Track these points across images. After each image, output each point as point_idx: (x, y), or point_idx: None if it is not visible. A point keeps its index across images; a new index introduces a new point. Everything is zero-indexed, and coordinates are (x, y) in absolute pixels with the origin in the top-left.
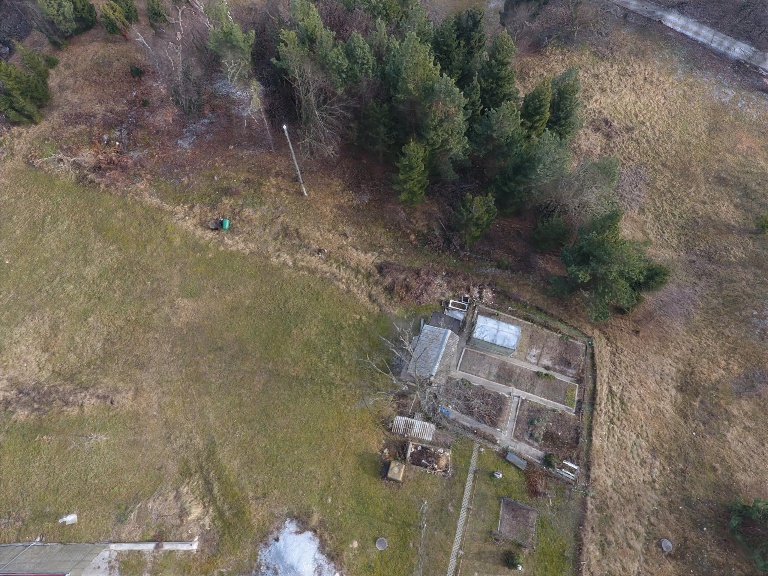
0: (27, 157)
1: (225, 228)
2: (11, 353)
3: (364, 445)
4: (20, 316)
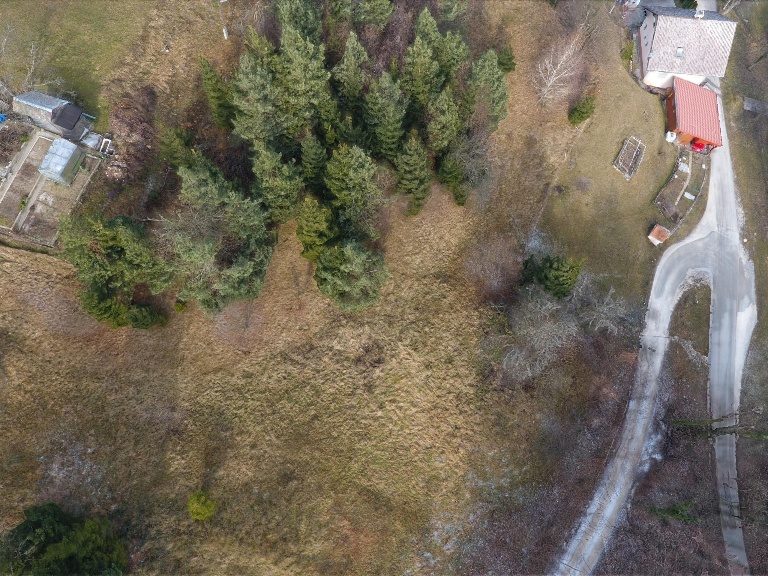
0: None
1: None
2: None
3: None
4: None
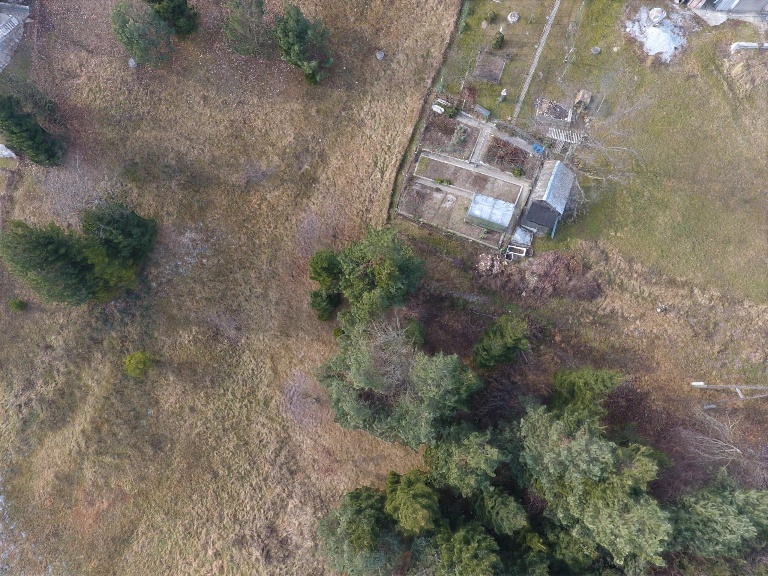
0: None
1: None
2: None
3: None
4: None
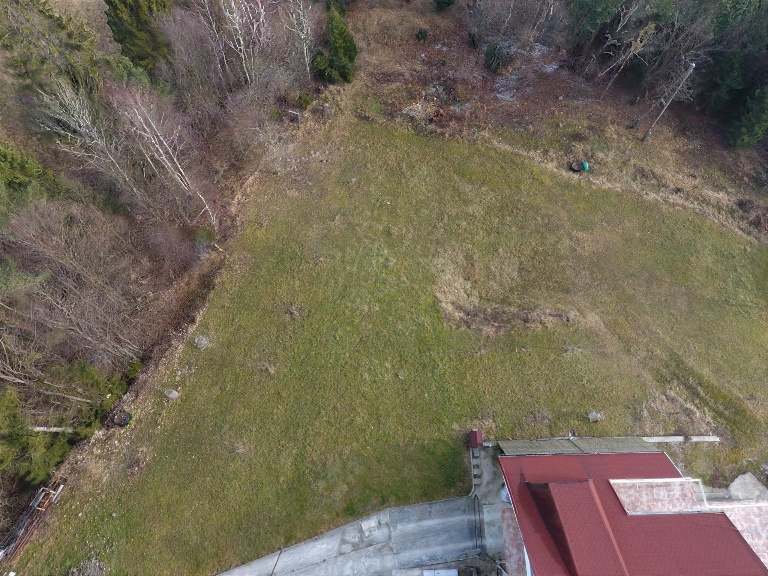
0: (355, 112)
1: (587, 170)
2: (442, 280)
3: None
4: (432, 249)
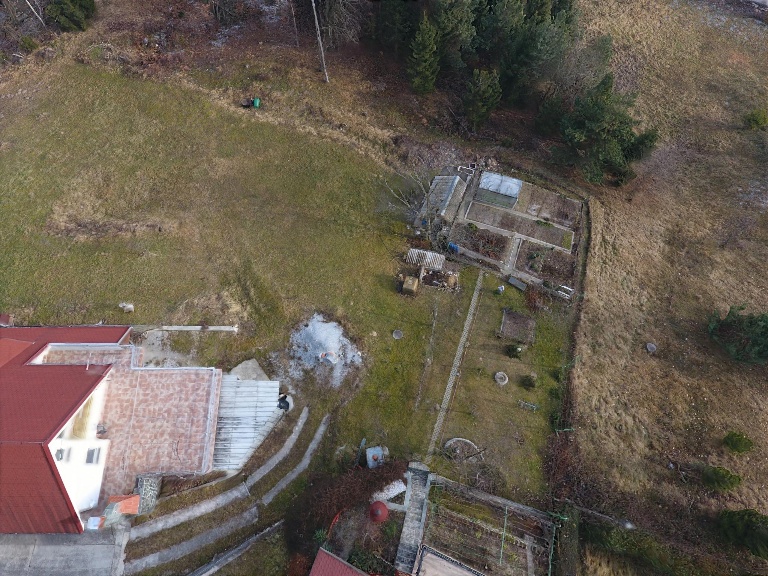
0: (76, 56)
1: (256, 105)
2: (70, 197)
3: (381, 270)
4: (76, 170)
